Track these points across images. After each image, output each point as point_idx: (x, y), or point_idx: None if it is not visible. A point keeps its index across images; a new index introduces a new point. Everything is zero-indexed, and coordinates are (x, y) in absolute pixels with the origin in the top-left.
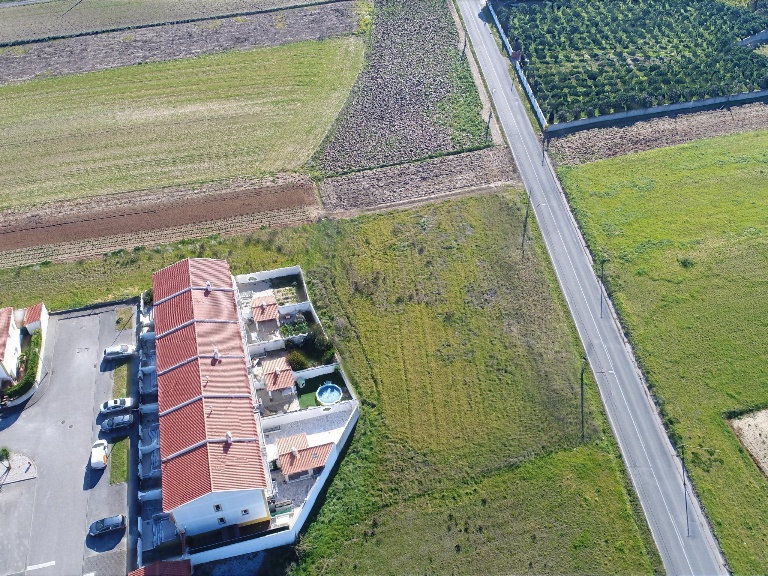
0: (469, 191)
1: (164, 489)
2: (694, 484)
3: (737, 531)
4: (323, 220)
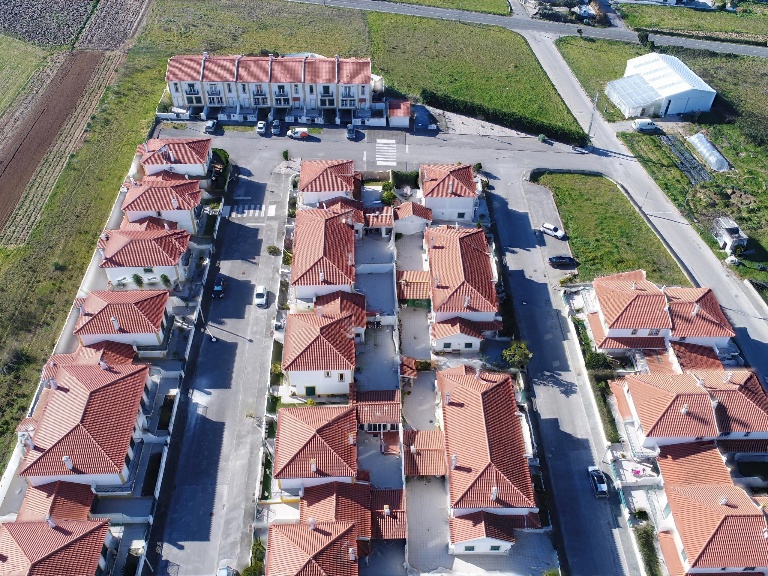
0: (149, 3)
1: (356, 83)
2: (398, 2)
3: (422, 1)
4: (128, 52)
